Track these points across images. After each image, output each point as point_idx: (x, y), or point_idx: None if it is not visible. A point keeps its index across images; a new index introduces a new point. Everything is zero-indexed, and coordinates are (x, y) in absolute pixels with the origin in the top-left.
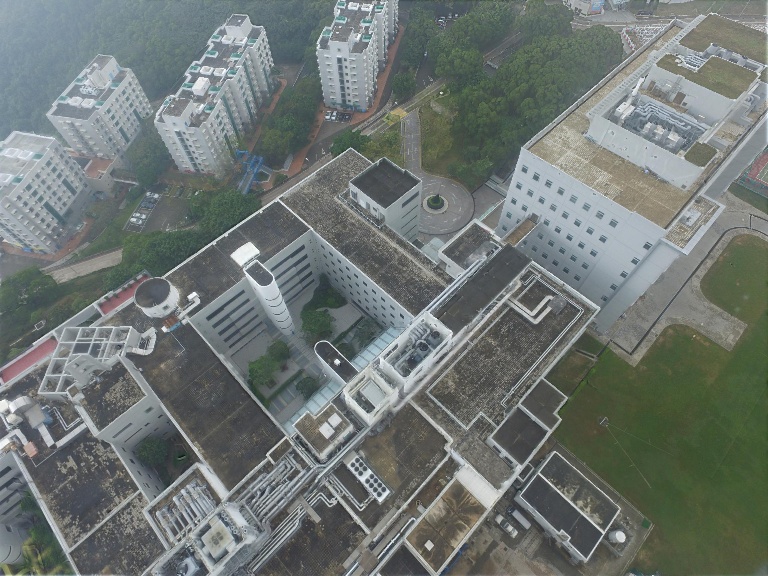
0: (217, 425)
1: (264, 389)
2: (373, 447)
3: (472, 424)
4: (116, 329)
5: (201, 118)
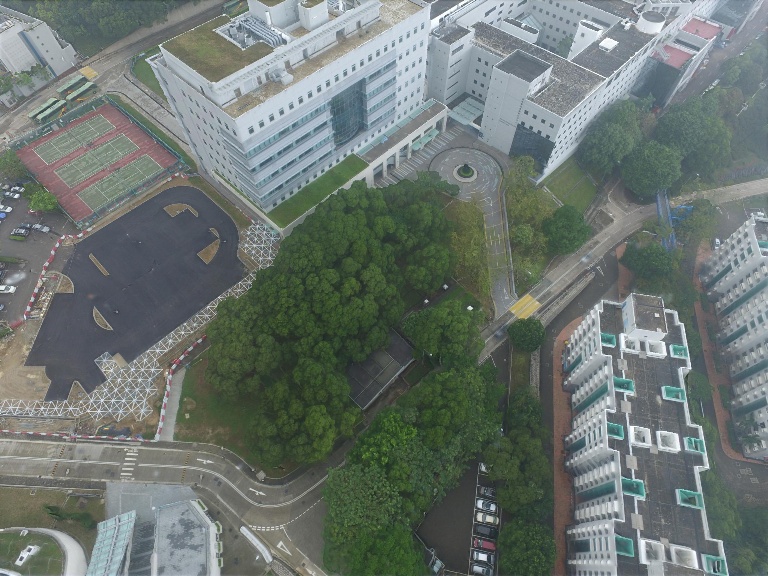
0: None
1: None
2: None
3: None
4: (660, 3)
5: (765, 235)
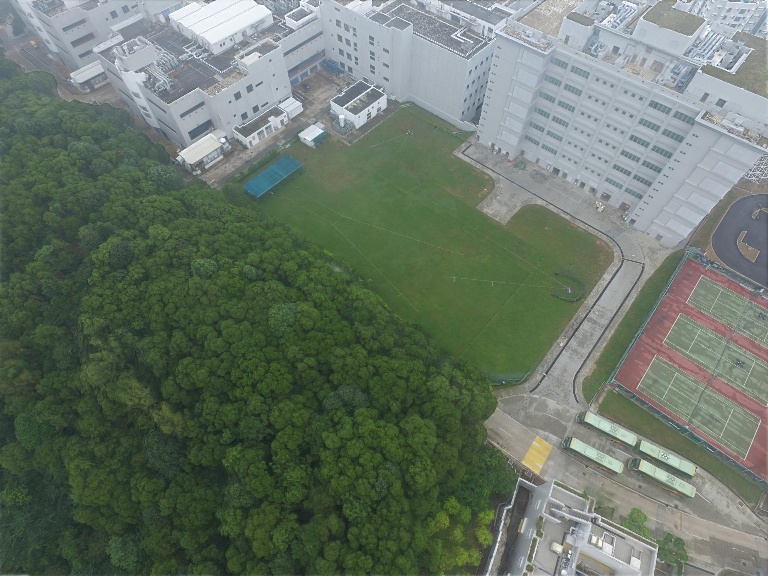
0: None
1: None
2: None
3: None
4: None
5: None
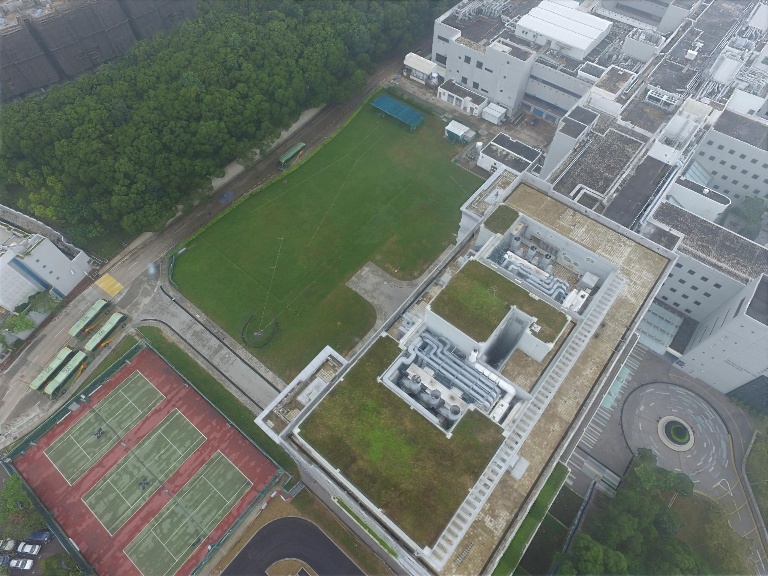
0: (766, 136)
1: (736, 221)
2: (664, 117)
3: (607, 131)
4: None
5: None
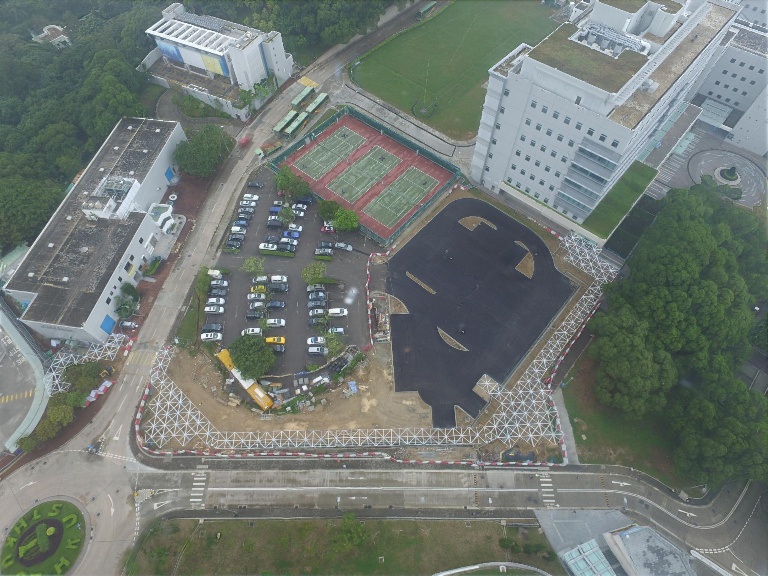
0: None
1: None
2: None
3: None
4: None
5: None
